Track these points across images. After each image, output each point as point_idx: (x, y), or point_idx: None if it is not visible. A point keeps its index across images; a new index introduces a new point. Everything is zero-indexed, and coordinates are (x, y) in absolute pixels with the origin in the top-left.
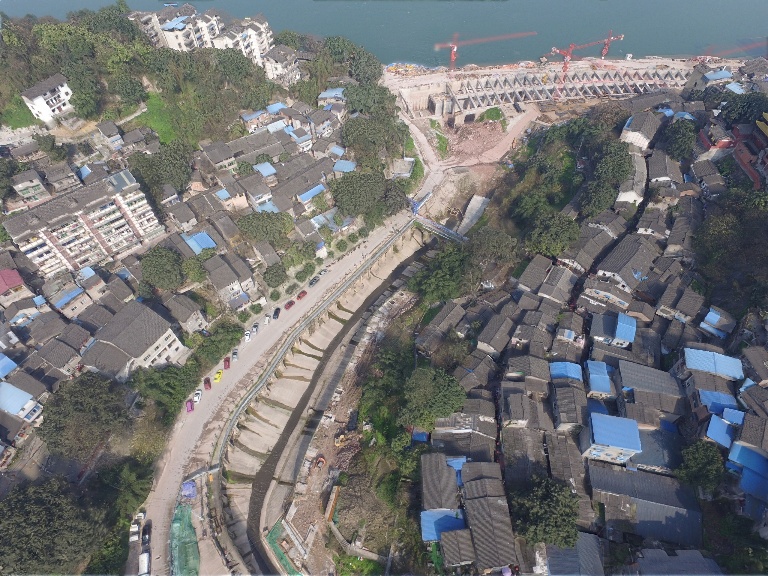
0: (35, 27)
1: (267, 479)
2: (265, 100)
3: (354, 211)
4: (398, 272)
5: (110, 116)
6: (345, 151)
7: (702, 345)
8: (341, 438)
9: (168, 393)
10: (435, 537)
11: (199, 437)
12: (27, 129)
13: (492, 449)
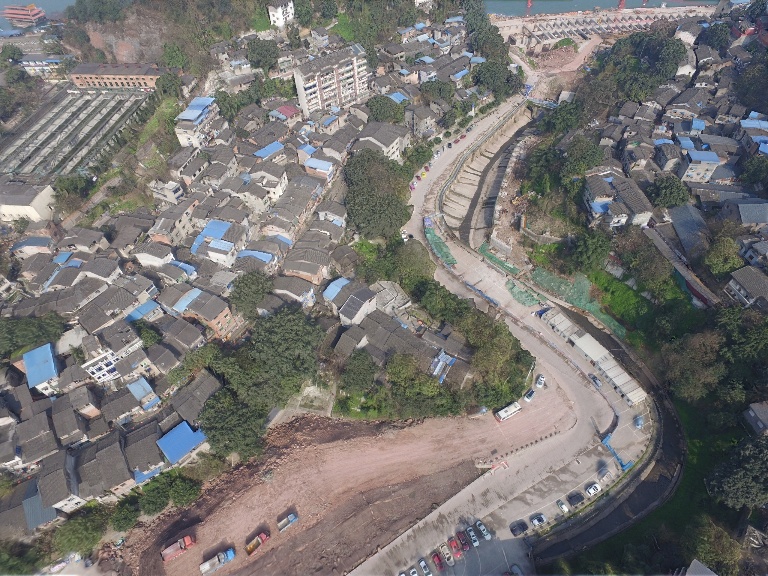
0: None
1: (467, 229)
2: (416, 18)
3: (492, 85)
4: (519, 133)
5: (316, 26)
6: (474, 53)
7: None
8: (517, 198)
9: None
10: (602, 211)
11: (424, 201)
12: (265, 32)
13: None
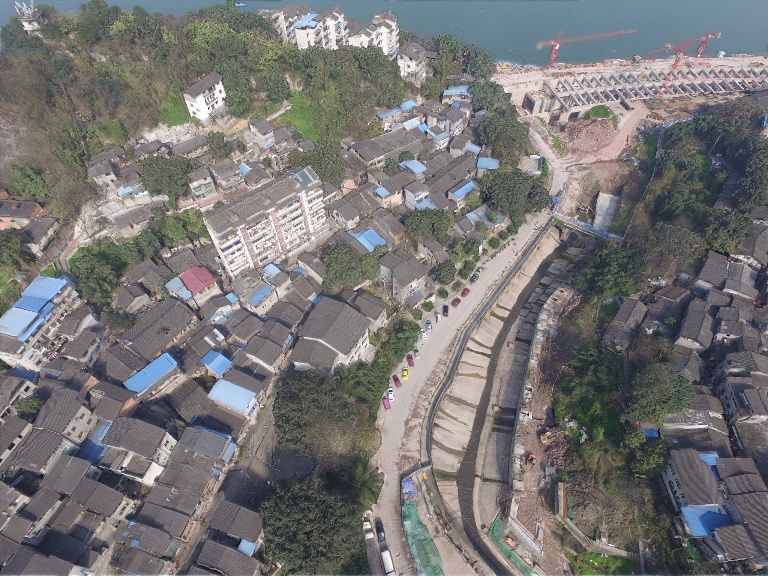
0: (189, 25)
1: (470, 476)
2: (402, 98)
3: (509, 208)
4: (543, 269)
5: (258, 114)
6: (482, 148)
7: None
8: (548, 435)
9: (371, 390)
10: (705, 533)
11: (403, 434)
12: (181, 127)
13: (728, 445)
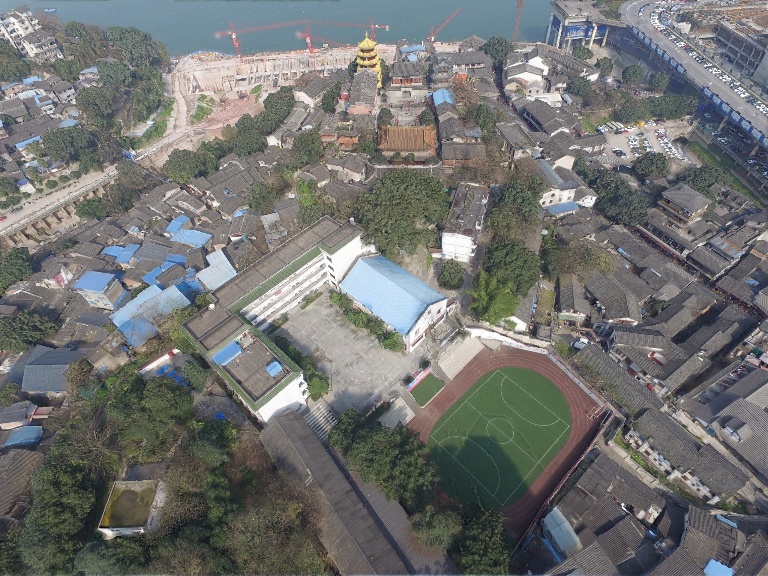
0: None
1: None
2: (16, 73)
3: (57, 156)
4: None
5: None
6: (79, 113)
7: (202, 229)
8: None
9: None
10: None
11: None
12: None
13: (35, 304)
